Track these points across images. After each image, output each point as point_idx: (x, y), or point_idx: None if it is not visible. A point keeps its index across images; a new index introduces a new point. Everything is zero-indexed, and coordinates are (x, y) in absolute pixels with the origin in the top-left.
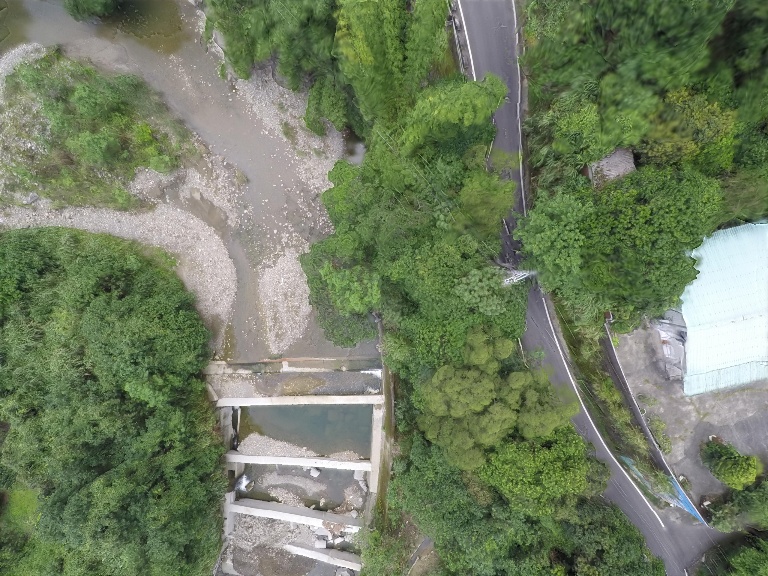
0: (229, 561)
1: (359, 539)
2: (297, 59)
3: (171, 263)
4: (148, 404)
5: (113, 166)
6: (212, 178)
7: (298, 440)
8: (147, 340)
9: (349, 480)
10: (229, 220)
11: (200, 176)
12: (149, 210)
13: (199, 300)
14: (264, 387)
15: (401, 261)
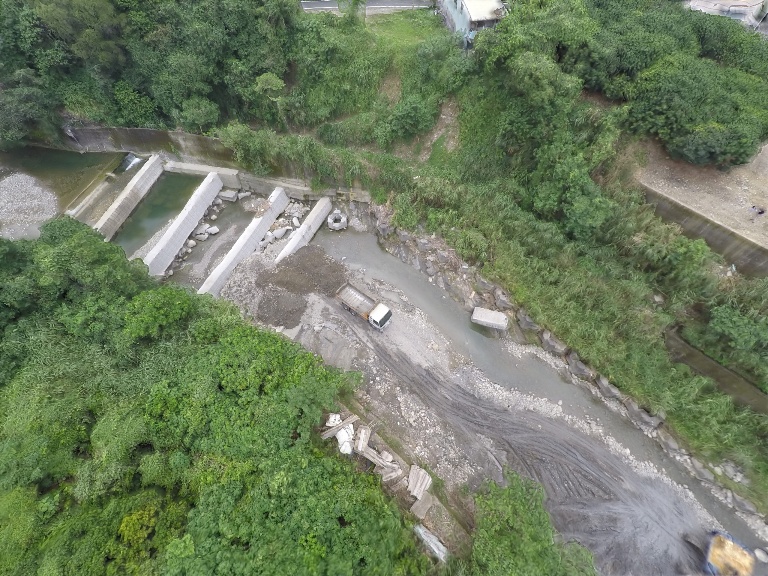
0: None
1: (228, 142)
2: None
3: None
4: None
5: None
6: None
7: (160, 227)
8: None
9: (238, 208)
10: None
11: None
12: None
13: None
14: None
15: None
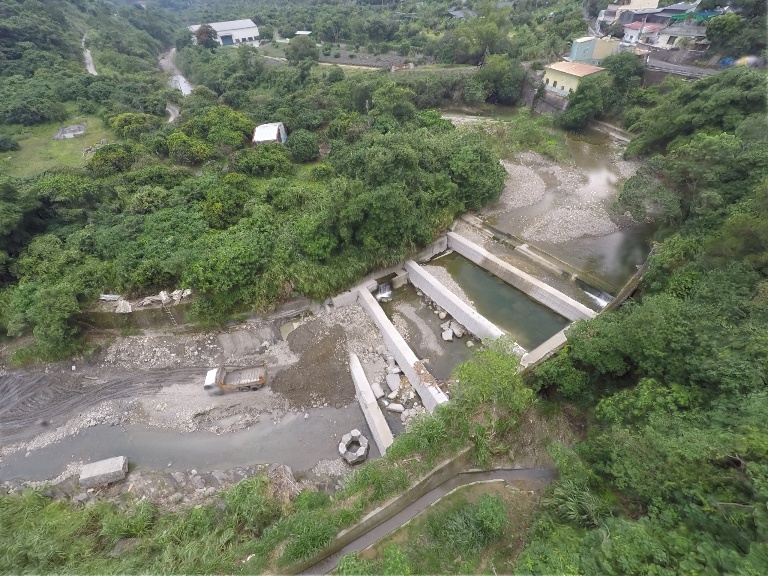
0: (297, 324)
1: None
2: (717, 114)
3: (507, 177)
4: (453, 168)
5: (520, 146)
6: (567, 173)
7: (472, 295)
8: (485, 158)
9: None
10: (560, 187)
11: (561, 169)
12: (516, 164)
13: (502, 195)
14: (491, 247)
15: (766, 153)
